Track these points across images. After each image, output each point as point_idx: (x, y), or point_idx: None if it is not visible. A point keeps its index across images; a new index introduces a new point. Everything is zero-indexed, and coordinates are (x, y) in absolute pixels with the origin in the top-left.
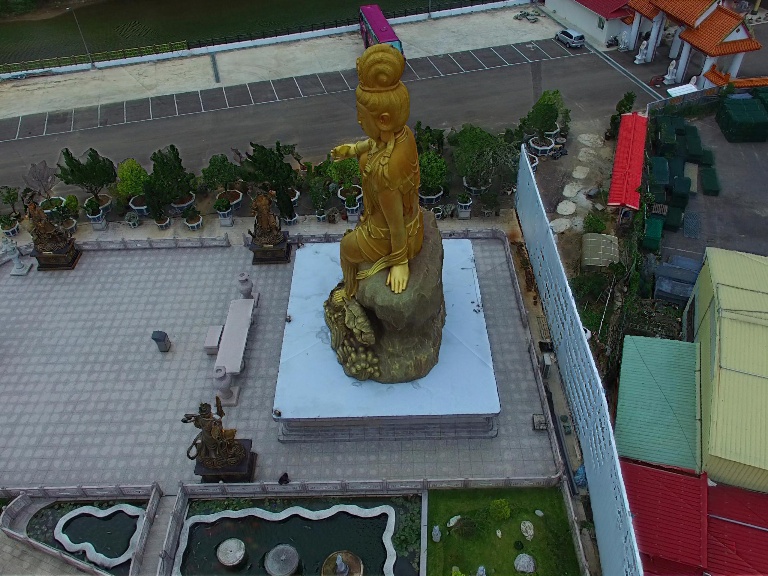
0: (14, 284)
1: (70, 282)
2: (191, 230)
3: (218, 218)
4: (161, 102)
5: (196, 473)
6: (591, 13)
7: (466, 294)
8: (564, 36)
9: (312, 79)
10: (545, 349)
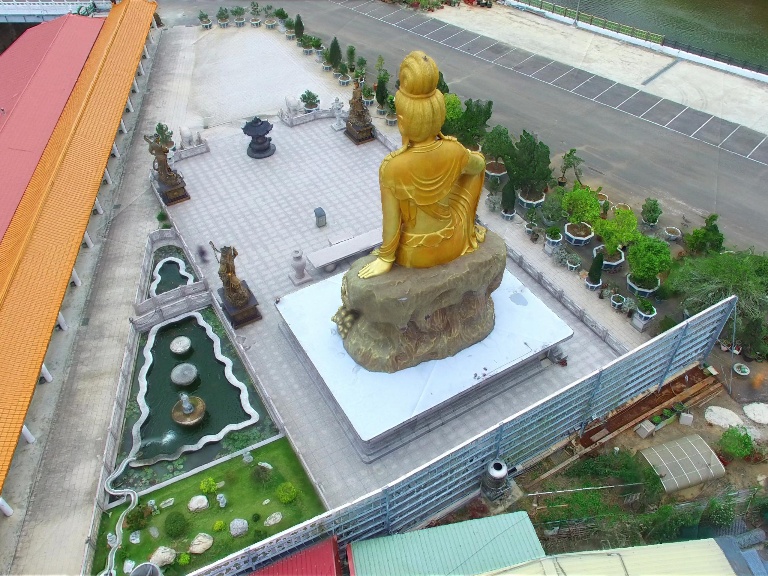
0: (325, 132)
1: (345, 151)
2: None
3: None
4: (576, 75)
5: (218, 291)
6: None
7: (493, 359)
8: None
9: (727, 127)
10: None
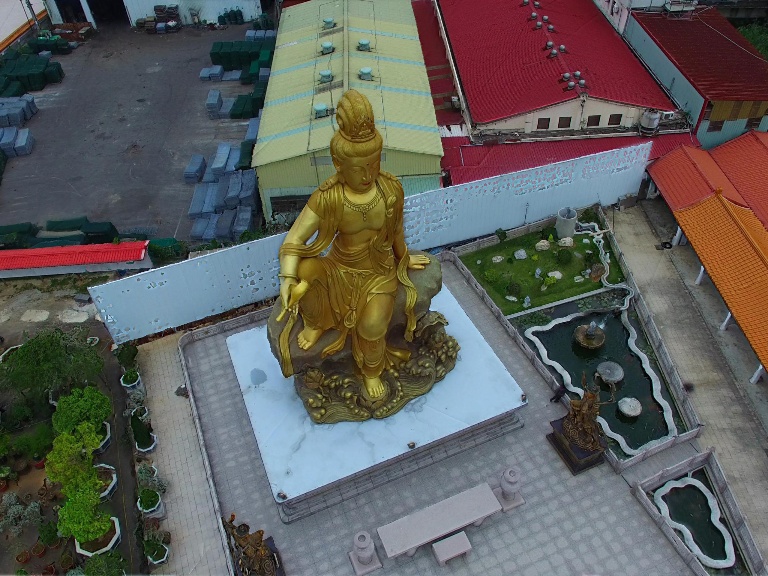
0: None
1: None
2: None
3: None
4: None
5: None
6: None
7: None
8: None
9: None
10: None
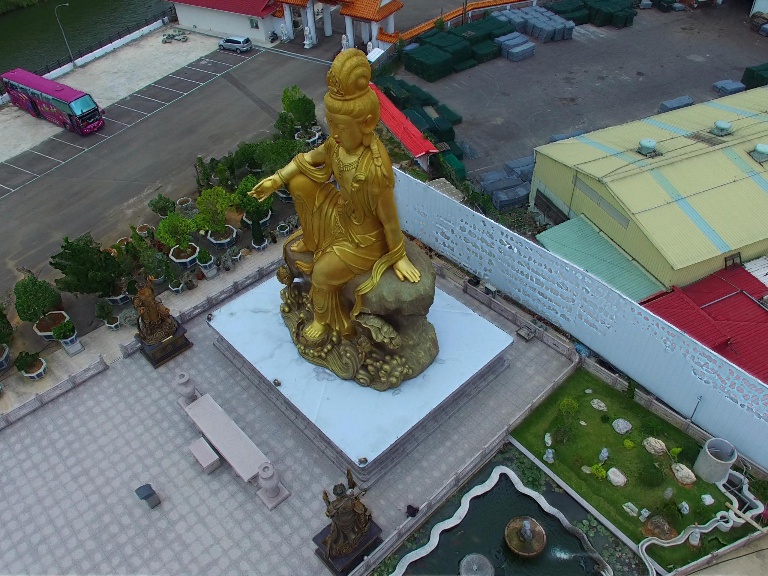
0: None
1: None
2: (37, 380)
3: (57, 351)
4: None
5: (340, 569)
6: (241, 17)
7: None
8: (230, 44)
9: (4, 169)
10: (474, 284)
